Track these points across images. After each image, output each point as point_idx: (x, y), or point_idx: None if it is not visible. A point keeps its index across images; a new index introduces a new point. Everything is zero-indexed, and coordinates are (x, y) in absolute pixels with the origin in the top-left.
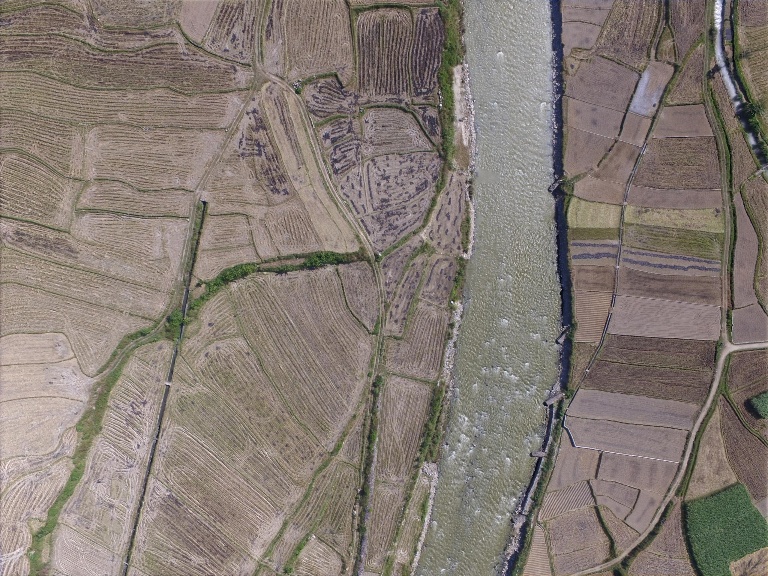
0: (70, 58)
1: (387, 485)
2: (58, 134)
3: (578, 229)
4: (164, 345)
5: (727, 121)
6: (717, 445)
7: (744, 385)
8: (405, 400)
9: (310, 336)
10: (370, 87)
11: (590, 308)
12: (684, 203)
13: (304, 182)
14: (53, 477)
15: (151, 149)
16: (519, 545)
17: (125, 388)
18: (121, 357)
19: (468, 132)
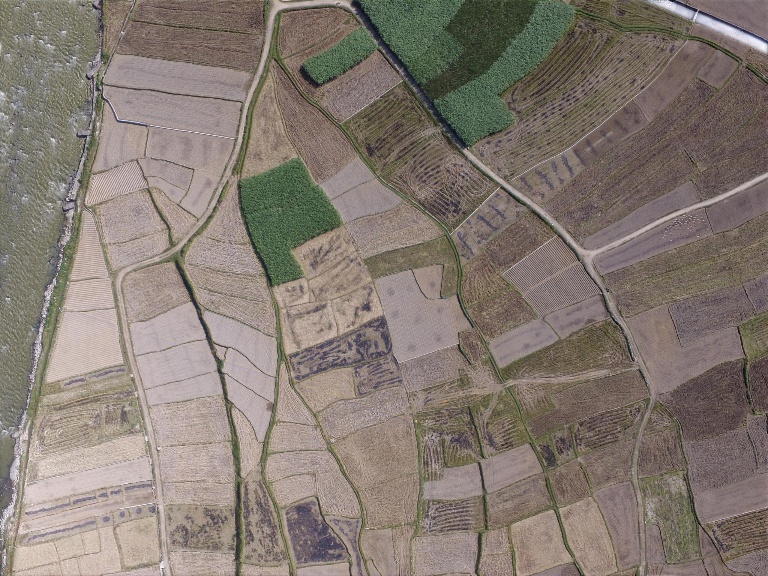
0: None
1: None
2: None
3: None
4: None
5: None
6: (273, 117)
7: (298, 49)
8: None
9: None
10: None
11: None
12: None
13: None
14: None
15: None
16: (71, 234)
17: None
18: None
19: None
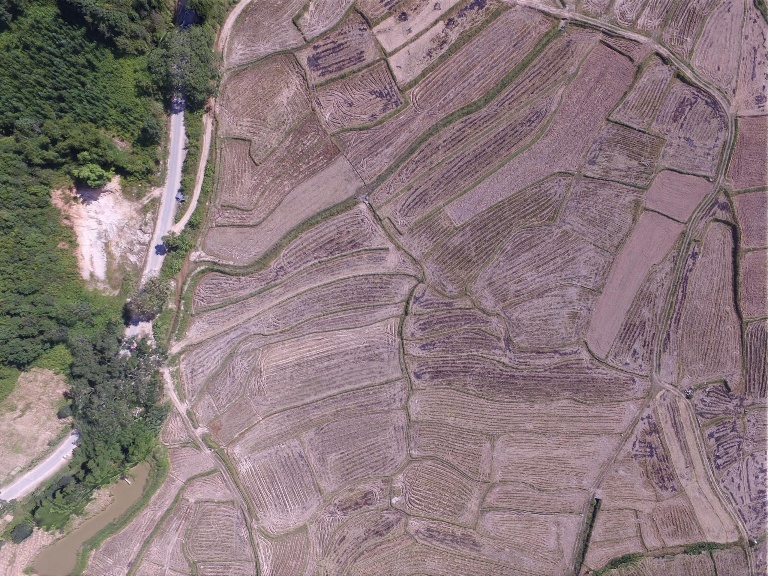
0: (485, 375)
1: None
2: (470, 443)
3: None
4: None
5: None
6: None
7: None
8: None
9: None
10: (755, 390)
11: None
12: None
13: (691, 479)
14: None
15: (552, 453)
16: None
17: None
18: None
19: None
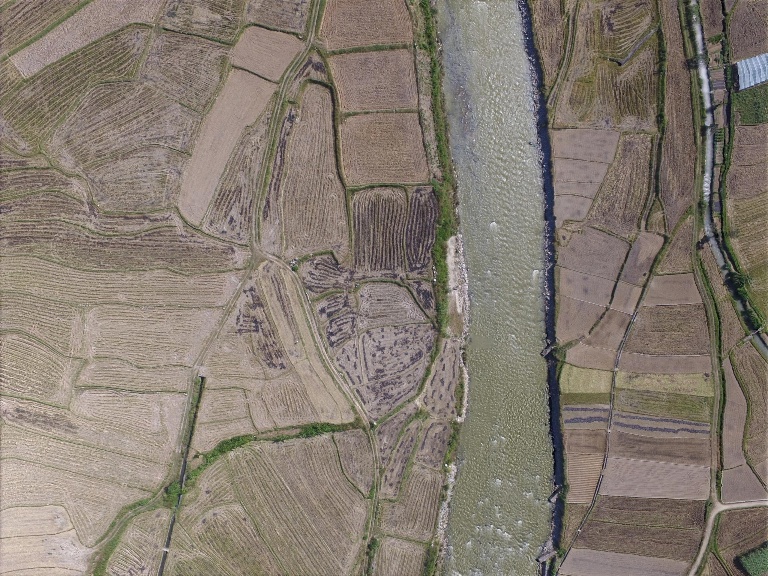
0: (70, 242)
1: None
2: (58, 315)
3: (570, 394)
4: (162, 513)
5: (716, 289)
6: None
7: (733, 543)
8: (400, 560)
9: (306, 501)
10: (365, 263)
11: (582, 470)
12: (674, 368)
13: (300, 356)
14: None
15: (150, 327)
16: None
17: (123, 555)
18: (119, 526)
19: (462, 300)
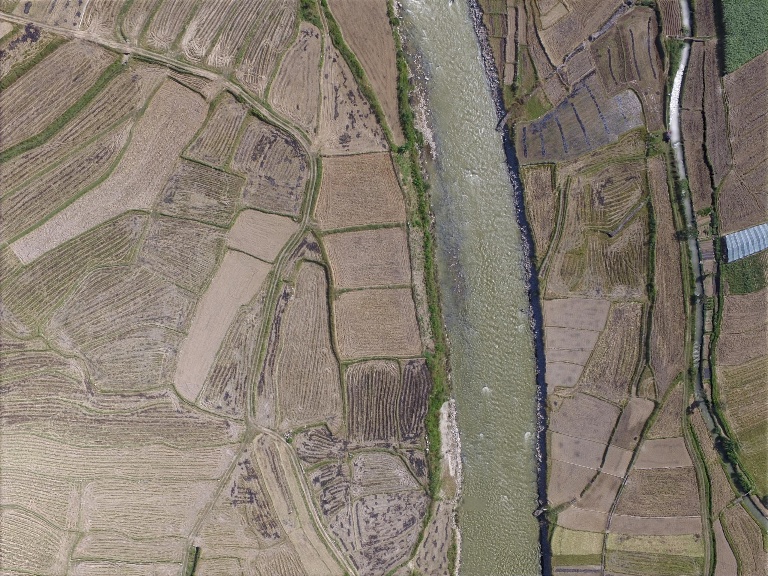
0: (67, 420)
1: None
2: (55, 490)
3: (562, 556)
4: None
5: (706, 453)
6: None
7: None
8: None
9: None
10: (359, 433)
11: None
12: (665, 529)
13: (294, 526)
14: None
15: (145, 500)
16: None
17: None
18: None
19: (455, 463)
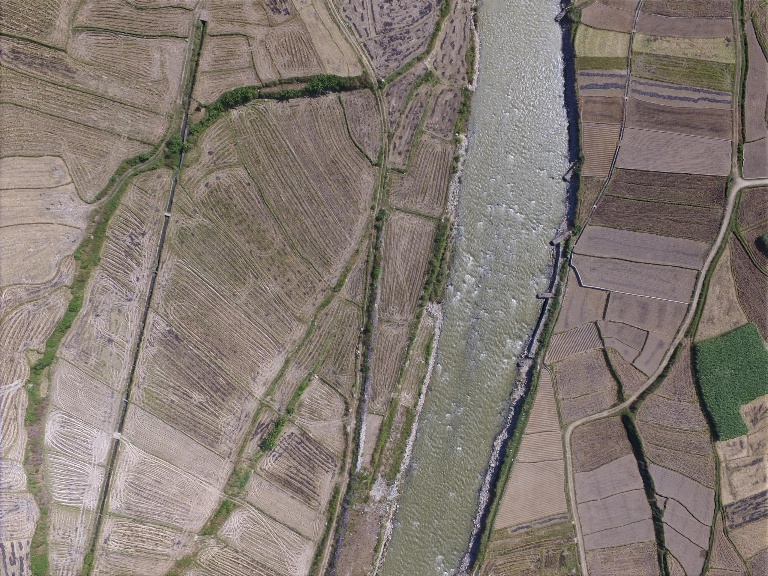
0: None
1: (391, 324)
2: None
3: (585, 58)
4: (163, 174)
5: None
6: (727, 285)
7: (755, 223)
8: (409, 236)
9: (312, 167)
10: None
11: (598, 141)
12: (694, 32)
13: (305, 2)
14: (51, 307)
15: None
16: (525, 389)
17: (124, 218)
18: (119, 184)
19: None
